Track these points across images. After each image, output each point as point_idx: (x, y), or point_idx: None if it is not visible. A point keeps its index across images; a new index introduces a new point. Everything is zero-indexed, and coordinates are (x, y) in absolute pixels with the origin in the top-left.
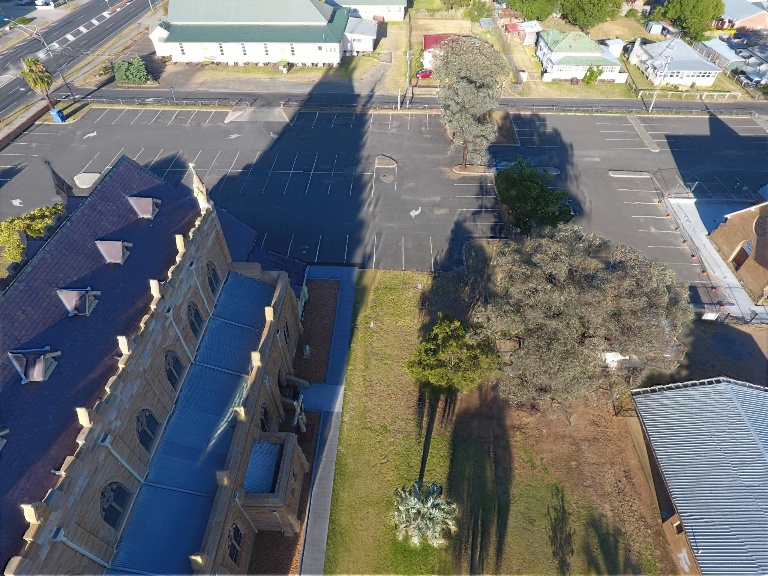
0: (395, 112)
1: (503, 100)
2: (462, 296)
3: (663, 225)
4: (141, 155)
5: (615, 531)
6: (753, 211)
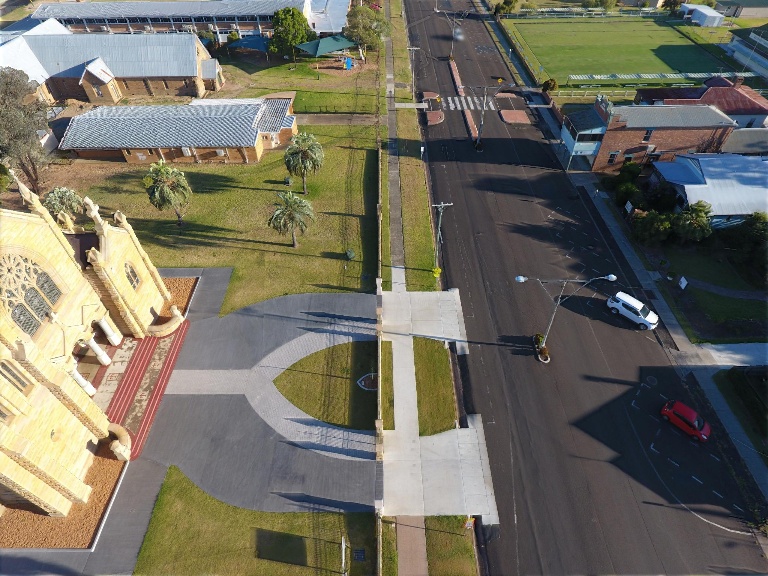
0: None
1: None
2: None
3: None
4: None
5: (121, 174)
6: None
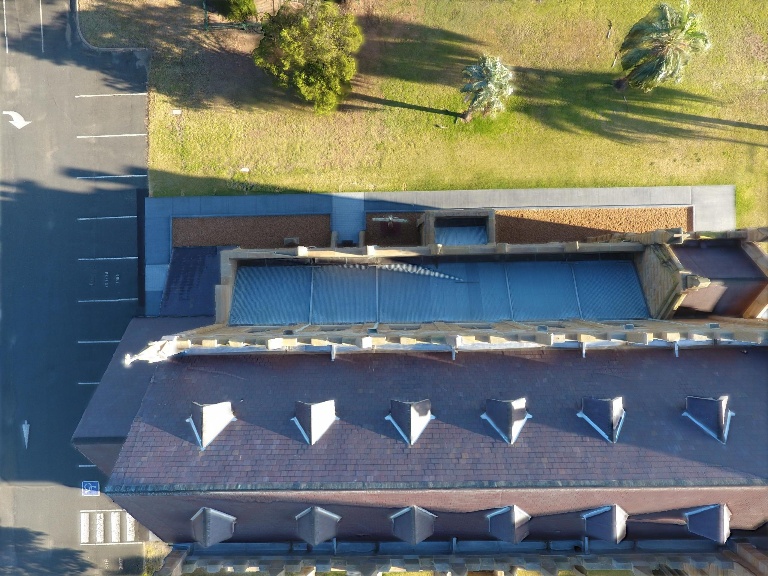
0: None
1: None
2: (190, 58)
3: None
4: None
5: None
6: None
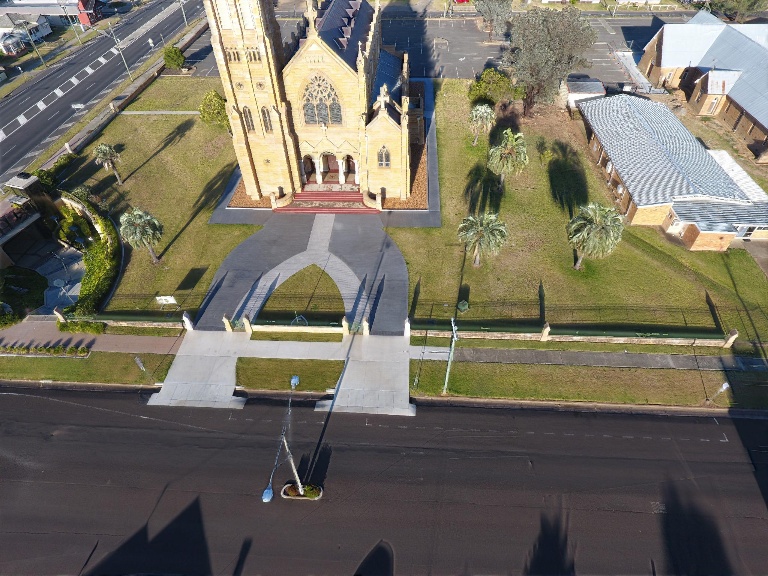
0: (442, 19)
1: (514, 13)
2: None
3: (610, 62)
4: (286, 39)
5: (566, 145)
6: (655, 39)
